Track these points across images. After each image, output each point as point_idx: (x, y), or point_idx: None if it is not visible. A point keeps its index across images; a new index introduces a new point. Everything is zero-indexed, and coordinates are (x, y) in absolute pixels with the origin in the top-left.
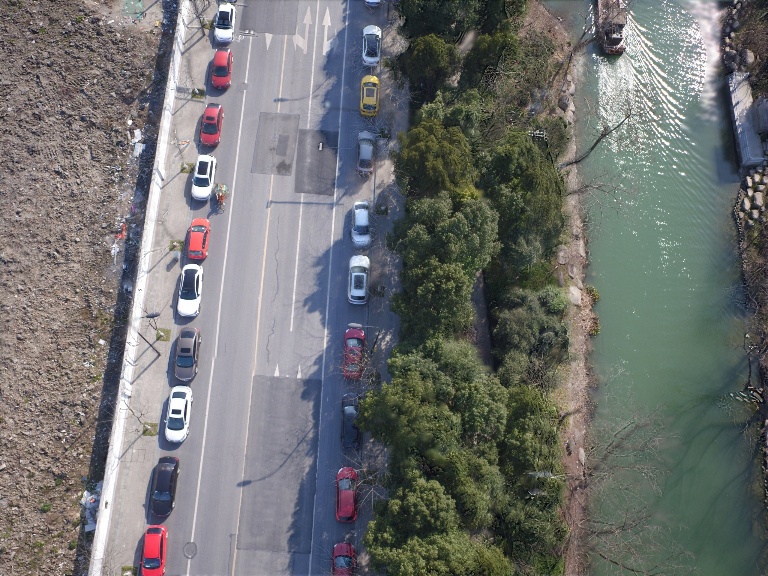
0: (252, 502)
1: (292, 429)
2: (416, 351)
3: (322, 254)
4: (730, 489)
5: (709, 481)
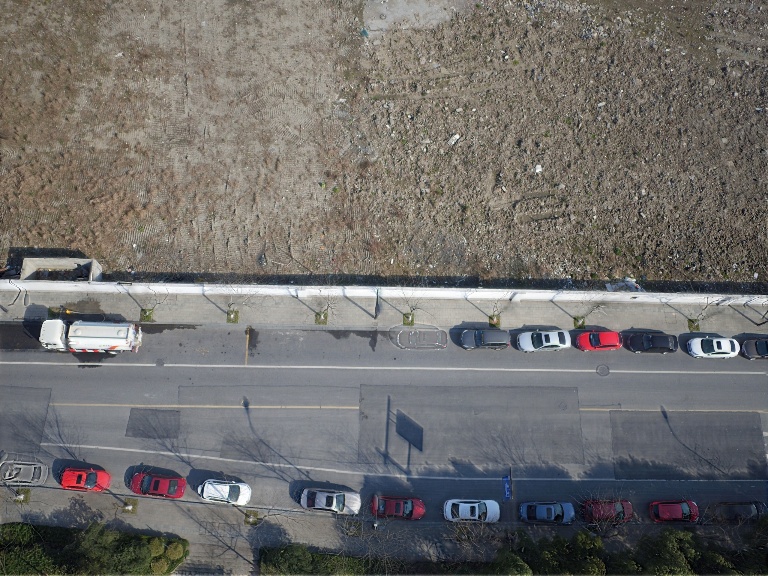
0: (650, 421)
1: (719, 453)
2: None
3: None
4: None
5: None
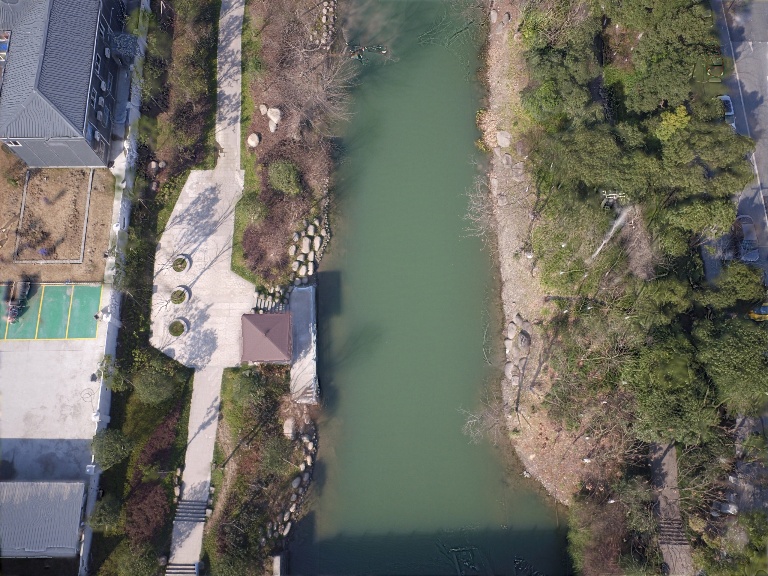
0: None
1: (745, 6)
2: (696, 3)
3: (759, 141)
4: (366, 3)
5: (384, 7)
